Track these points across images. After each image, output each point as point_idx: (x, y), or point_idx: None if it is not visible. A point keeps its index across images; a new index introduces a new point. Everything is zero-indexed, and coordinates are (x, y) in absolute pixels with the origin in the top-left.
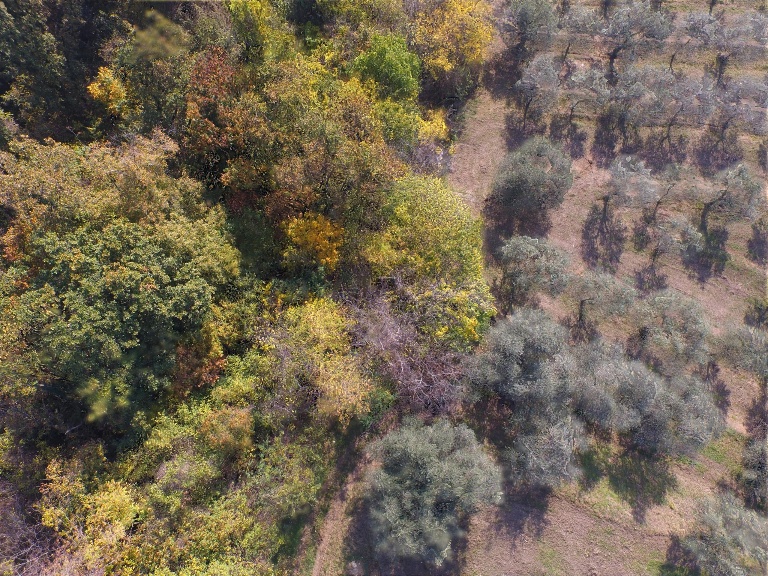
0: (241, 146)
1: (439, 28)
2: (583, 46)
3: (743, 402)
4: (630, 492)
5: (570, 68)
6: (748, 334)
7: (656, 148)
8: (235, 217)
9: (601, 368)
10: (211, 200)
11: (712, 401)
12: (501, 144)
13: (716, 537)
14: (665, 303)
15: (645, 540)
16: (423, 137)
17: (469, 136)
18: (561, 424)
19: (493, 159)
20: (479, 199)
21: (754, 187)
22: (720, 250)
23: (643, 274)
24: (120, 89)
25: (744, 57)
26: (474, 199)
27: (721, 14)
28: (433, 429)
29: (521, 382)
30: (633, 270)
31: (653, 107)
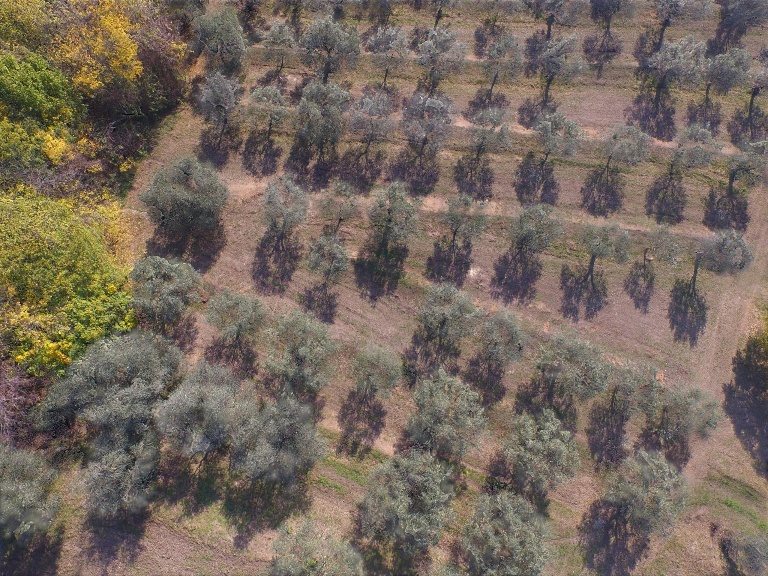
0: None
1: None
2: (298, 60)
3: (399, 423)
4: (244, 516)
5: (280, 83)
6: (414, 353)
7: (352, 164)
8: None
9: (245, 389)
10: None
11: (367, 422)
12: None
13: (307, 564)
14: (283, 325)
15: (245, 566)
16: (55, 156)
17: (160, 152)
18: (119, 451)
19: (180, 176)
20: (155, 217)
21: (396, 206)
22: (396, 268)
23: (314, 293)
24: None
25: (459, 71)
26: (150, 217)
27: (446, 27)
28: (44, 453)
29: (91, 407)
30: (304, 288)
31: (353, 122)
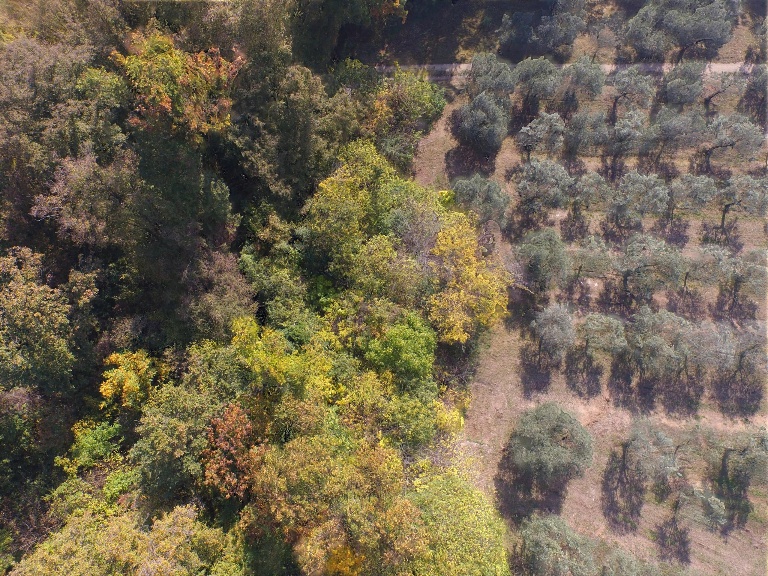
0: (259, 489)
1: (454, 303)
2: (596, 263)
3: None
4: None
5: (584, 289)
6: None
7: (673, 381)
8: (253, 544)
9: None
10: (228, 517)
11: None
12: (516, 382)
13: None
14: None
15: None
16: (441, 421)
17: (484, 374)
18: None
19: (509, 400)
20: (496, 449)
21: None
22: (742, 499)
23: (665, 528)
24: (133, 384)
25: (759, 273)
26: (491, 450)
27: (734, 222)
28: None
29: None
30: (654, 524)
31: None
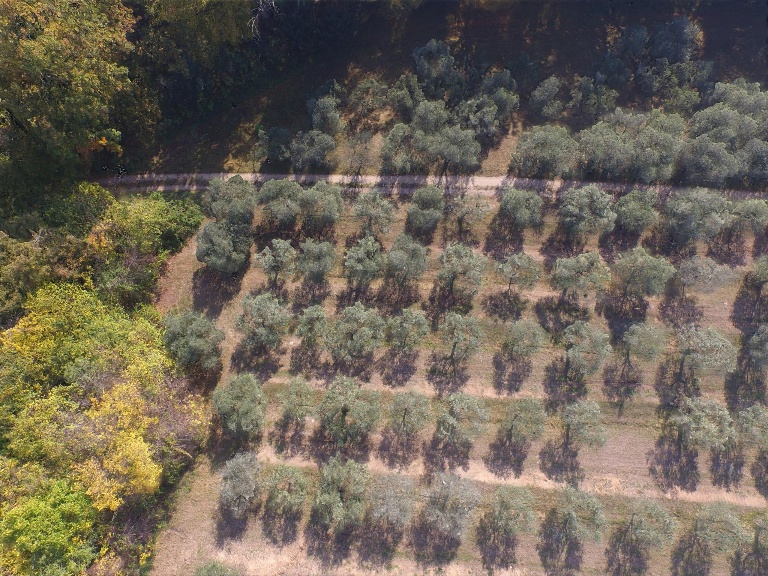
0: None
1: None
2: (316, 397)
3: None
4: None
5: (298, 426)
6: None
7: (373, 526)
8: None
9: None
10: None
11: None
12: (211, 529)
13: None
14: None
15: None
16: None
17: (179, 521)
18: None
19: (200, 549)
20: None
21: None
22: None
23: None
24: None
25: None
26: None
27: (464, 352)
28: None
29: None
30: None
31: (373, 479)
